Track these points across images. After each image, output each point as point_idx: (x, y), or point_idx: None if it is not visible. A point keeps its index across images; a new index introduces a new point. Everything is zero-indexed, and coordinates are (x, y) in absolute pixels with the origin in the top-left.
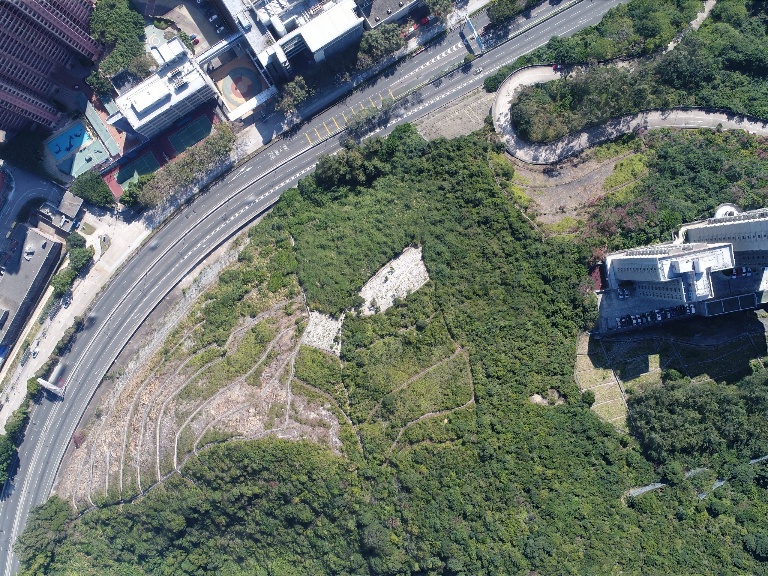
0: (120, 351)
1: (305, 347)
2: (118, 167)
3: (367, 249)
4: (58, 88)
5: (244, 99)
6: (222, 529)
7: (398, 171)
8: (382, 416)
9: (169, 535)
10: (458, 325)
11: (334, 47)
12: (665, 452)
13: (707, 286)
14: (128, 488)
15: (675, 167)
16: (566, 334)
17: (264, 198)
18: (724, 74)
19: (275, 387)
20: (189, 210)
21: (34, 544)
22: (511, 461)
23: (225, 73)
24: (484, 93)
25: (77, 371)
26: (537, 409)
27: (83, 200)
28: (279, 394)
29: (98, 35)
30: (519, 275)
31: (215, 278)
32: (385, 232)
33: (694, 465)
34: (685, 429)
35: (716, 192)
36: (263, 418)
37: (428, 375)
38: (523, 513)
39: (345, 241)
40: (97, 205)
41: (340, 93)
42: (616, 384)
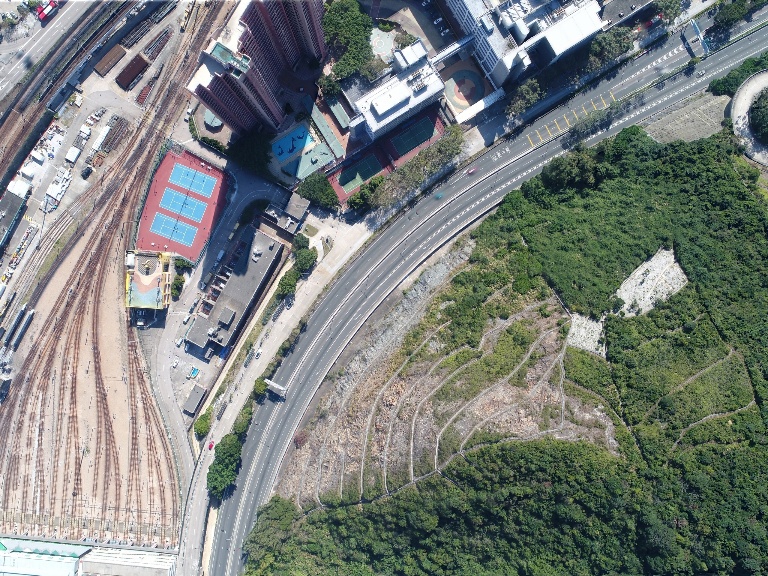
0: (341, 352)
1: (572, 349)
2: (340, 169)
3: (618, 251)
4: (283, 90)
5: (467, 101)
6: (476, 529)
7: (631, 173)
8: (660, 417)
9: (417, 535)
10: (730, 327)
11: (569, 50)
12: None
13: None
14: (372, 488)
15: None
16: None
17: (485, 200)
18: None
19: (545, 388)
20: (412, 212)
21: (267, 544)
22: None
23: (448, 75)
24: (712, 96)
25: (299, 372)
26: None
27: (310, 202)
28: (551, 395)
29: (330, 38)
30: None
31: (446, 280)
32: (633, 234)
33: None
34: None
35: None
36: (537, 419)
37: (705, 377)
38: None
39: (589, 243)
40: (320, 207)
41: (562, 96)
42: None
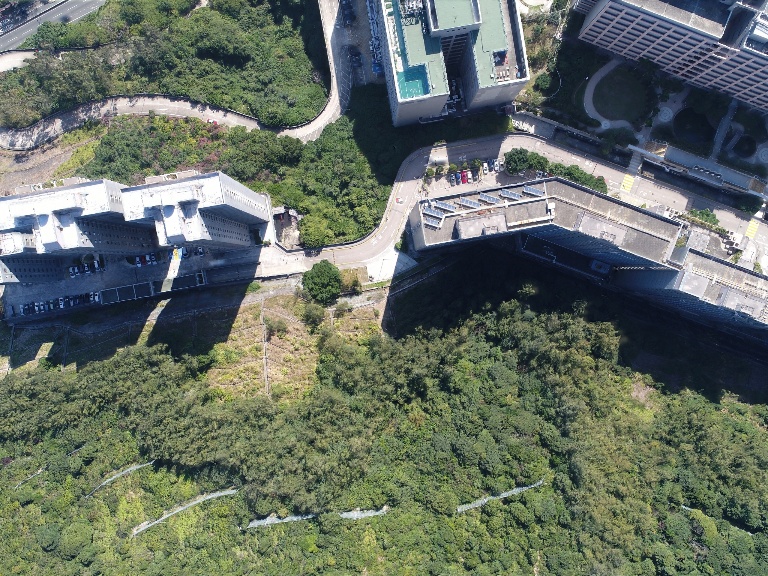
0: None
1: None
2: None
3: None
4: None
5: None
6: None
7: None
8: None
9: None
10: None
11: None
12: None
13: None
14: None
15: (102, 153)
16: None
17: None
18: (192, 61)
19: None
20: None
21: None
22: None
23: None
24: None
25: None
26: None
27: None
28: None
29: None
30: None
31: None
32: None
33: (18, 453)
34: (10, 417)
35: None
36: None
37: None
38: None
39: None
40: None
41: None
42: (5, 371)
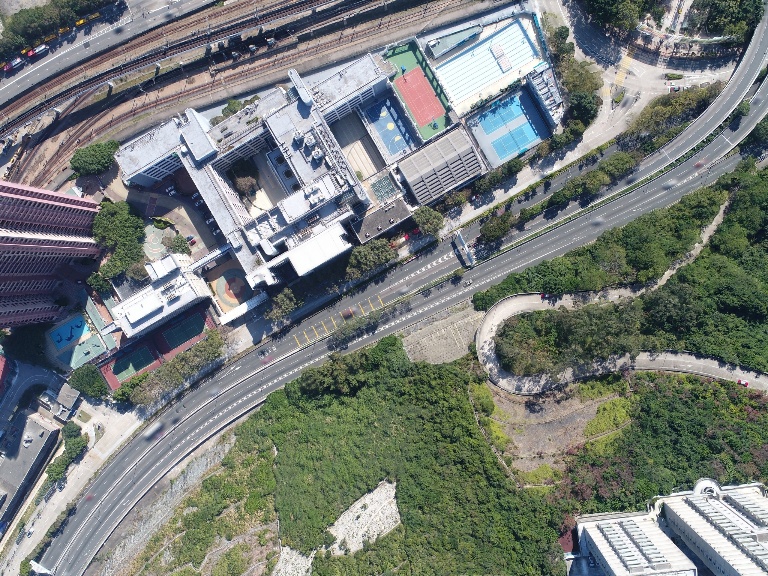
0: (109, 535)
1: None
2: (115, 359)
3: (342, 480)
4: (62, 282)
5: (237, 299)
6: None
7: (381, 388)
8: None
9: None
10: None
11: (323, 264)
12: None
13: None
14: None
15: (657, 427)
16: None
17: (252, 396)
18: (718, 318)
19: None
20: (179, 405)
21: None
22: None
23: (219, 274)
24: (472, 310)
25: (68, 552)
26: None
27: (80, 392)
28: None
29: (99, 239)
30: (490, 528)
31: (199, 480)
32: (361, 462)
33: None
34: None
35: (697, 462)
36: None
37: None
38: None
39: (323, 464)
40: None
41: (330, 297)
42: None
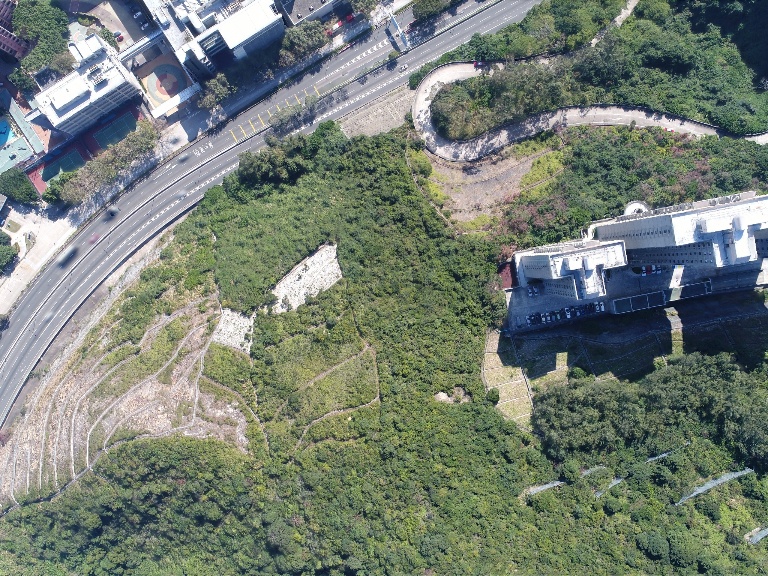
0: (46, 349)
1: (215, 345)
2: (43, 164)
3: (283, 247)
4: None
5: (169, 96)
6: (136, 527)
7: (320, 168)
8: (288, 414)
9: (86, 533)
10: (366, 323)
11: (255, 44)
12: (563, 450)
13: (597, 284)
14: (46, 486)
15: (588, 164)
16: (475, 332)
17: (190, 195)
18: (643, 71)
19: (184, 385)
20: (114, 207)
21: None
22: (412, 459)
23: (150, 70)
24: (408, 90)
25: (2, 369)
26: (441, 407)
27: (7, 197)
28: (187, 392)
29: (20, 32)
30: (431, 273)
31: (137, 276)
32: (301, 230)
33: (592, 463)
34: (583, 427)
35: (627, 189)
36: (171, 416)
37: (334, 373)
38: (422, 511)
39: (263, 239)
40: (22, 202)
41: (265, 90)
42: (523, 382)
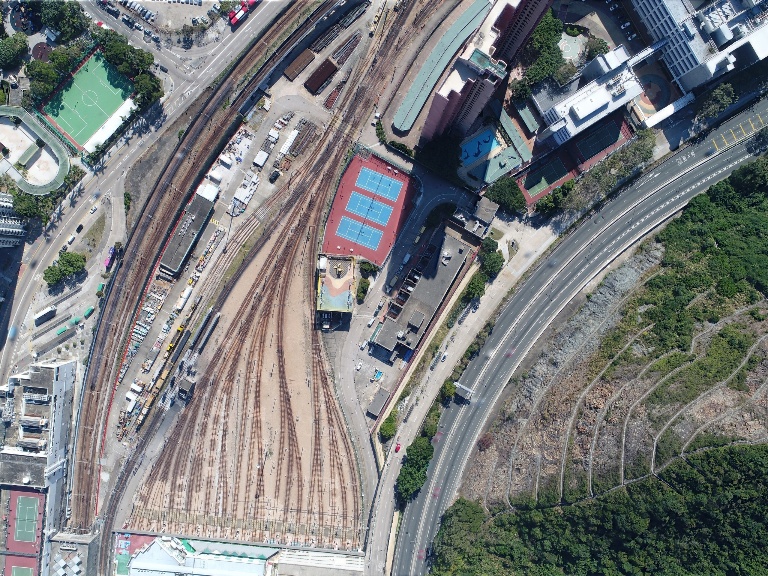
0: (525, 355)
1: None
2: (526, 173)
3: None
4: None
5: (653, 106)
6: (687, 532)
7: None
8: None
9: (623, 537)
10: None
11: None
12: None
13: None
14: (574, 491)
15: None
16: None
17: (670, 204)
18: None
19: None
20: (598, 215)
21: (461, 546)
22: None
23: None
24: None
25: (484, 375)
26: None
27: (499, 206)
28: None
29: None
30: None
31: (639, 283)
32: None
33: None
34: None
35: None
36: (764, 422)
37: None
38: None
39: None
40: (506, 210)
41: (747, 100)
42: None
